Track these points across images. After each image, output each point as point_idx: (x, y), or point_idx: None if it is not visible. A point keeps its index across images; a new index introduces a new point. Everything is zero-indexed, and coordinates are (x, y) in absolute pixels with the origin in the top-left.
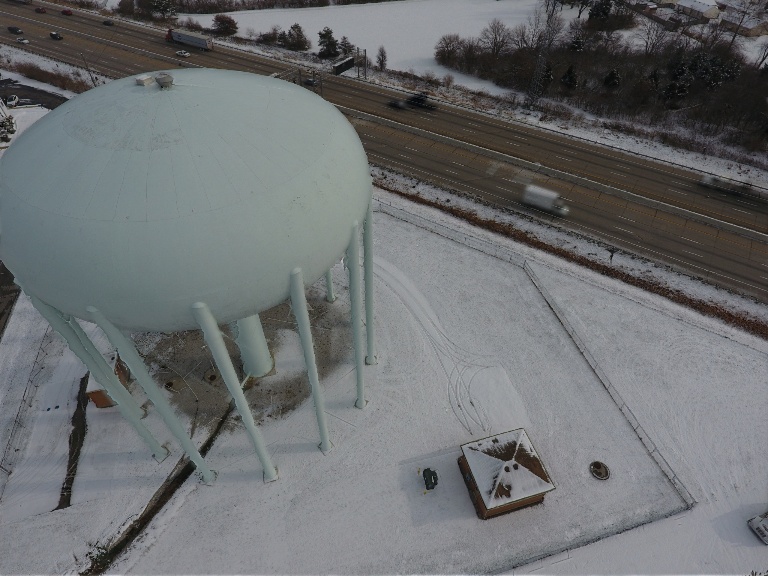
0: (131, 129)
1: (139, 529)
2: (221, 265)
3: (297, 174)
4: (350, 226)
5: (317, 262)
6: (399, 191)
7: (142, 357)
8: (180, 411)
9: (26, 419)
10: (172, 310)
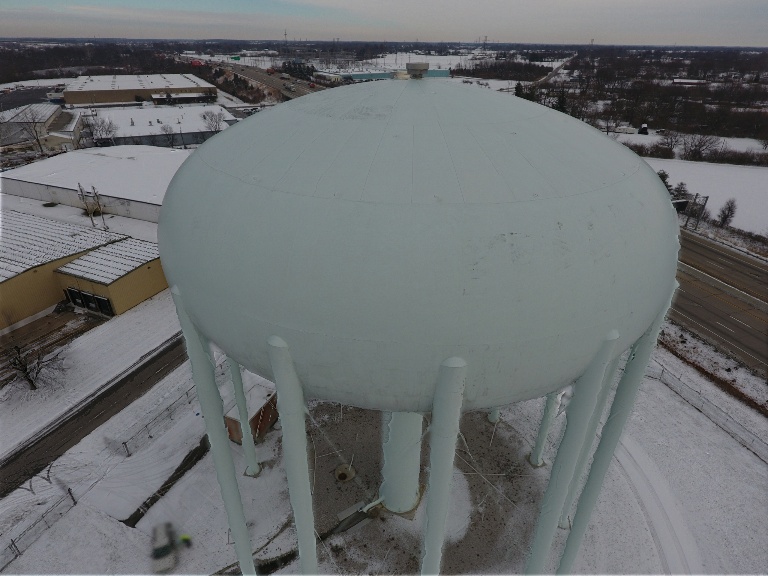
0: (340, 99)
1: None
2: (331, 290)
3: (531, 200)
4: (599, 334)
5: (503, 367)
6: (700, 366)
7: None
8: None
9: (178, 412)
10: (245, 333)
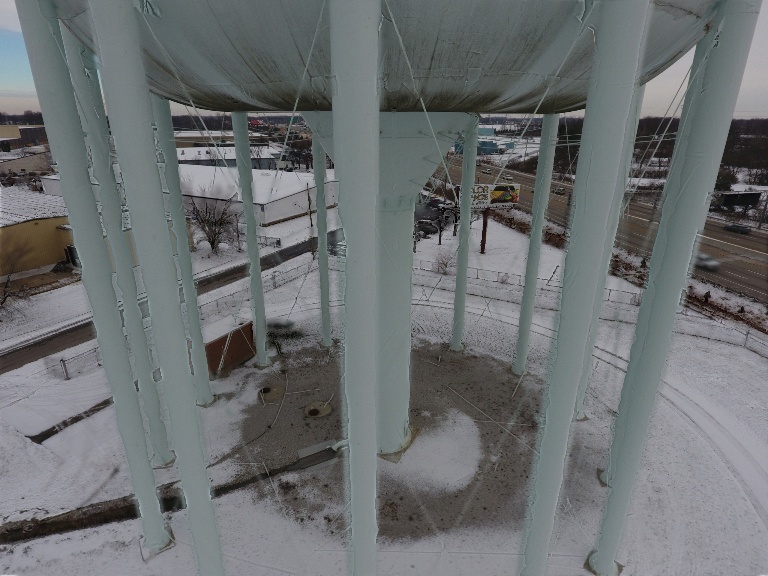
0: None
1: (21, 536)
2: None
3: None
4: None
5: None
6: None
7: (277, 352)
8: (241, 425)
9: None
10: None
